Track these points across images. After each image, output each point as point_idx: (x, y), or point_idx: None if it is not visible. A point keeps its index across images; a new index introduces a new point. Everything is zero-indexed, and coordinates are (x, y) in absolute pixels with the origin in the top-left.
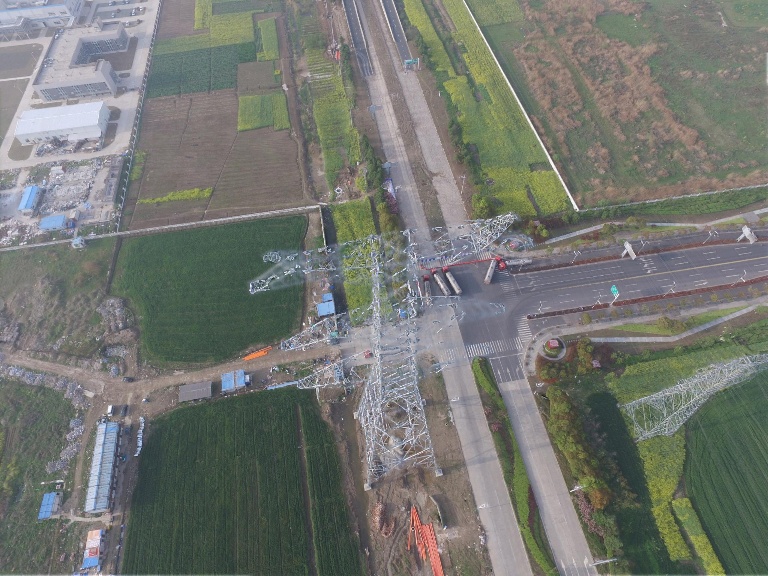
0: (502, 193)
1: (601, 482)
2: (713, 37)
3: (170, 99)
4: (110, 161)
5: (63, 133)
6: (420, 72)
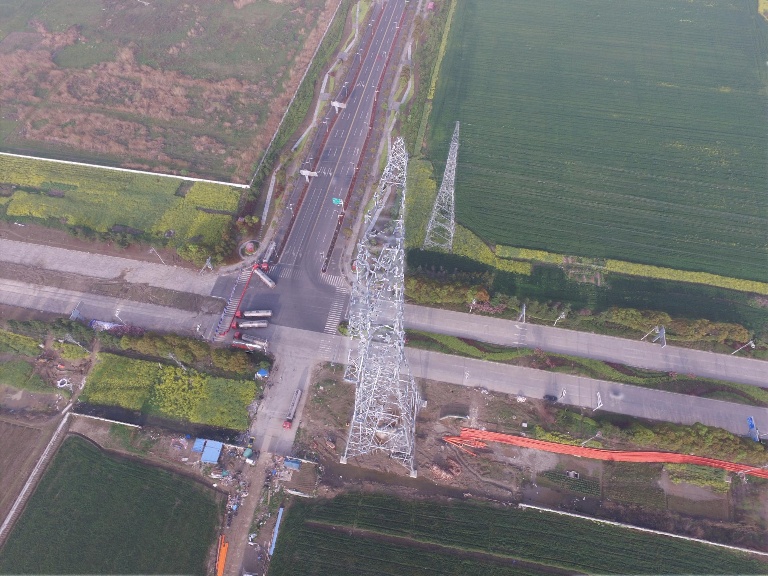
0: (190, 230)
1: (473, 287)
2: (152, 16)
3: None
4: None
5: None
6: None
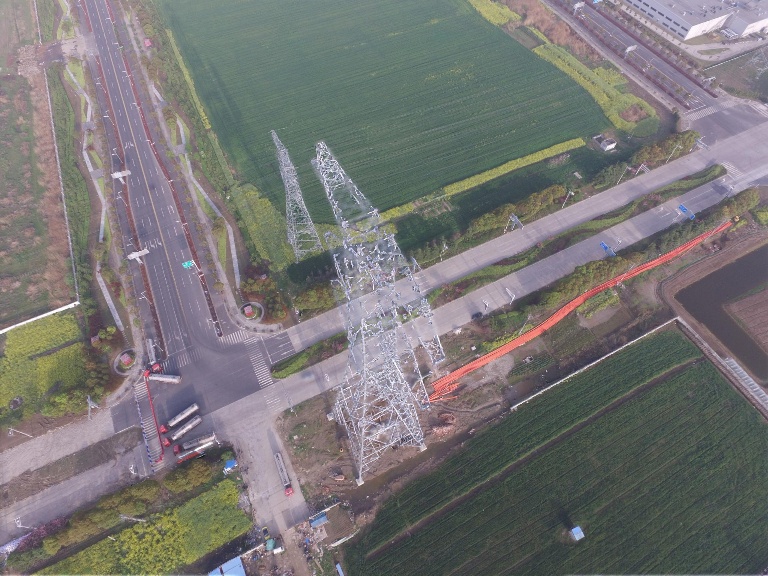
0: (39, 385)
1: None
2: None
3: None
4: None
5: None
6: None
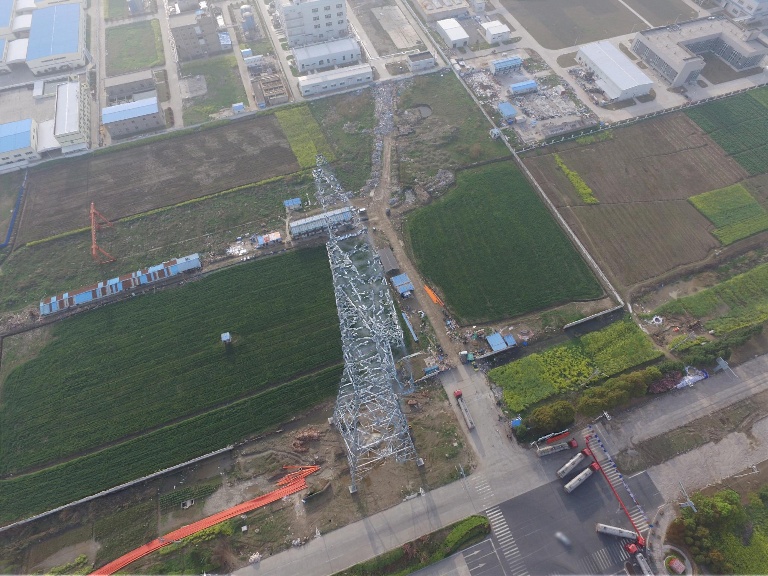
0: None
1: None
2: None
3: (695, 129)
4: (588, 117)
5: (601, 75)
6: None
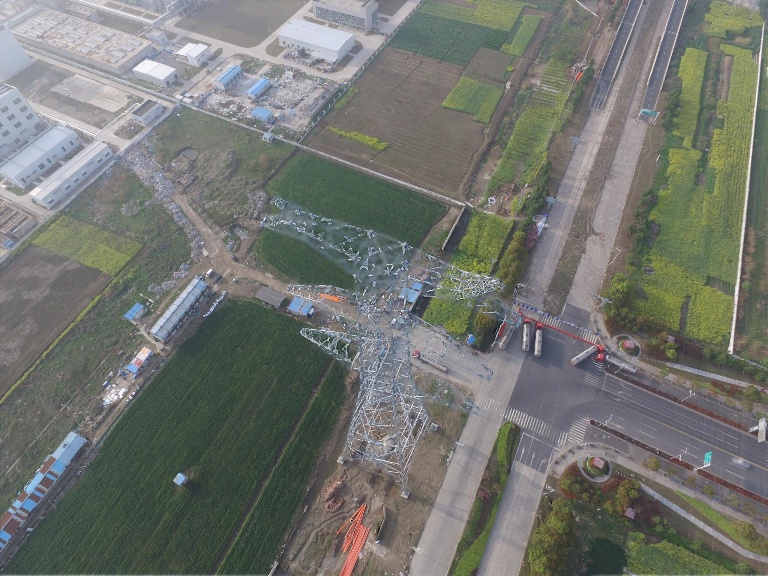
0: (654, 288)
1: None
2: None
3: (406, 54)
4: (329, 85)
5: (311, 47)
6: (653, 127)
